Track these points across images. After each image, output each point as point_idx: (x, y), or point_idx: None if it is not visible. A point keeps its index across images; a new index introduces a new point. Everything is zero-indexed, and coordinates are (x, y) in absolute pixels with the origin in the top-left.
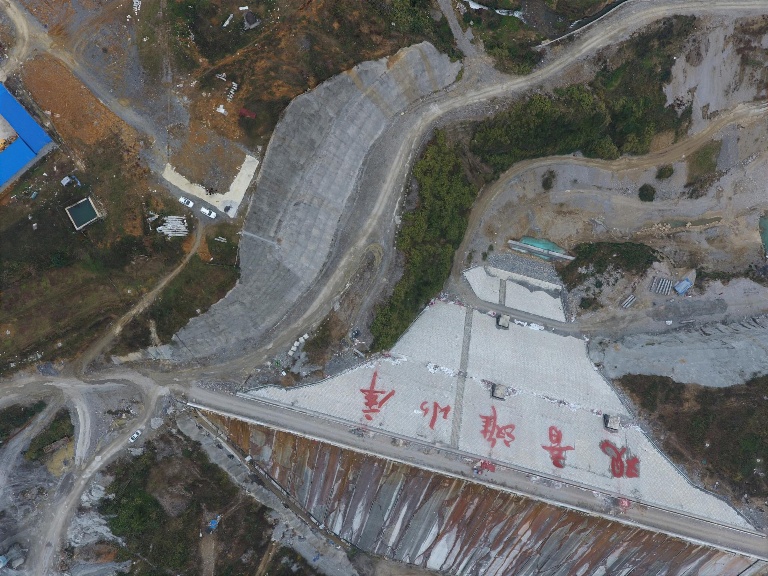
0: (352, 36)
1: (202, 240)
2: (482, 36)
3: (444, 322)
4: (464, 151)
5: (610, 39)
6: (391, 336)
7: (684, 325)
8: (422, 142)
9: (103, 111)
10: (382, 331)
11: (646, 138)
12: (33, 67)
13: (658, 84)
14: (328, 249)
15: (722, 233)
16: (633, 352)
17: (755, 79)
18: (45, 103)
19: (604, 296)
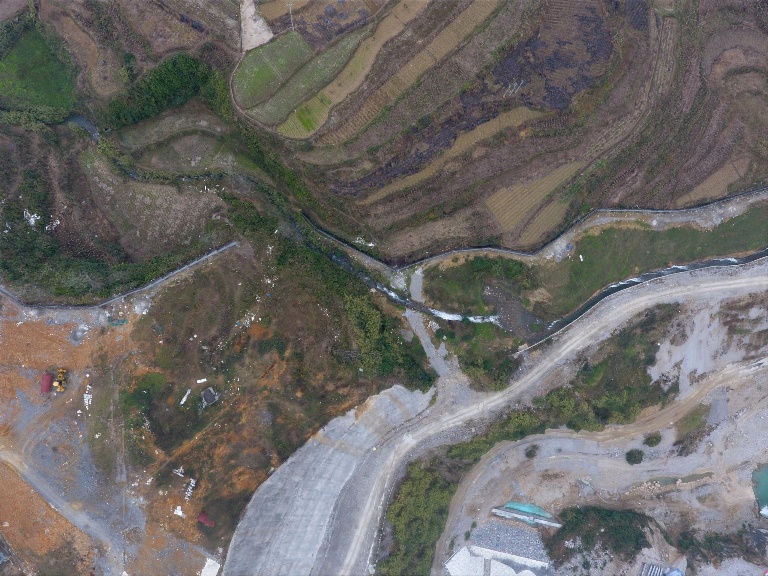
0: (317, 399)
1: None
2: (456, 351)
3: None
4: (441, 460)
5: (590, 339)
6: None
7: None
8: (395, 481)
9: (55, 517)
10: None
11: (631, 416)
12: None
13: (642, 368)
14: None
15: (714, 491)
16: None
17: (743, 343)
18: None
19: None
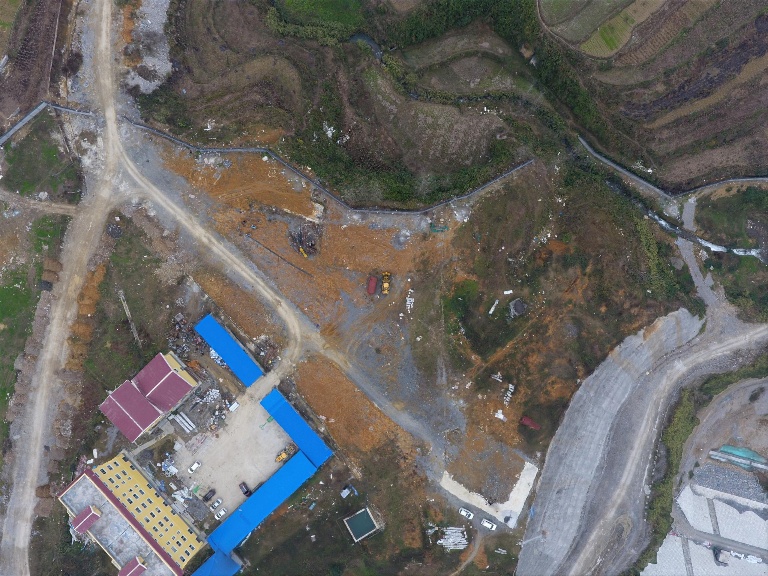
0: (616, 315)
1: (480, 550)
2: (722, 282)
3: (665, 561)
4: None
5: None
6: None
7: None
8: (669, 405)
9: (378, 416)
10: None
11: None
12: (306, 370)
13: None
14: (578, 523)
15: None
16: None
17: None
18: (319, 407)
19: None
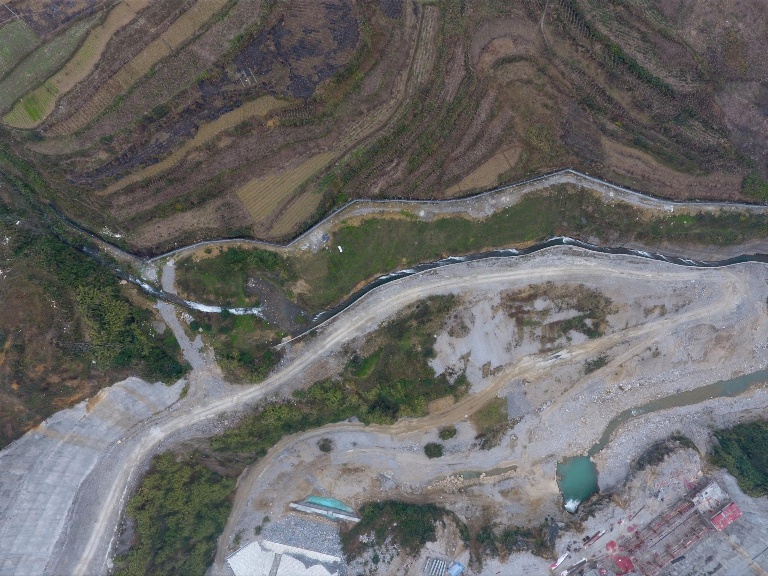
0: (38, 391)
1: None
2: (212, 343)
3: None
4: (206, 454)
5: (357, 331)
6: None
7: None
8: (138, 474)
9: None
10: None
11: (418, 409)
12: None
13: (422, 360)
14: None
15: (517, 484)
16: None
17: (536, 335)
18: None
19: (378, 575)
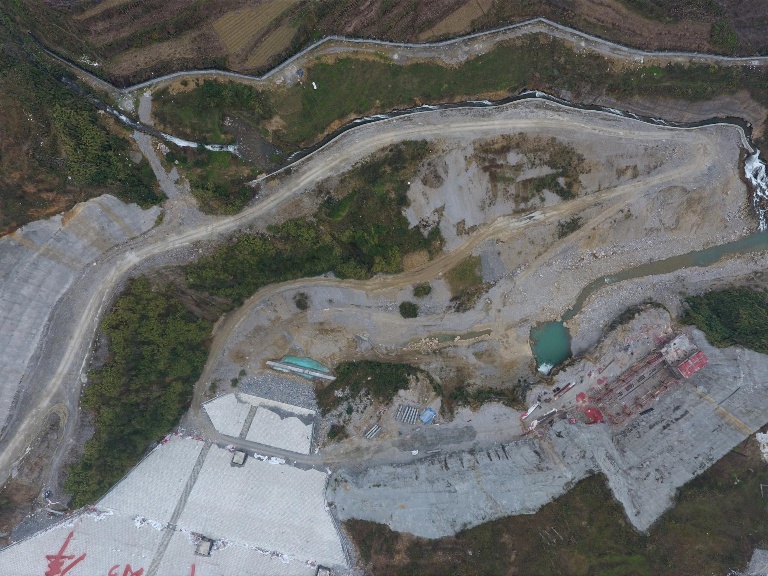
0: (14, 198)
1: None
2: (188, 175)
3: (172, 463)
4: (182, 290)
5: (331, 170)
6: (92, 492)
7: (430, 455)
8: (113, 294)
9: None
10: (78, 489)
11: (392, 261)
12: None
13: (396, 208)
14: (8, 412)
15: (491, 347)
16: (361, 493)
17: (510, 194)
18: None
19: (352, 424)
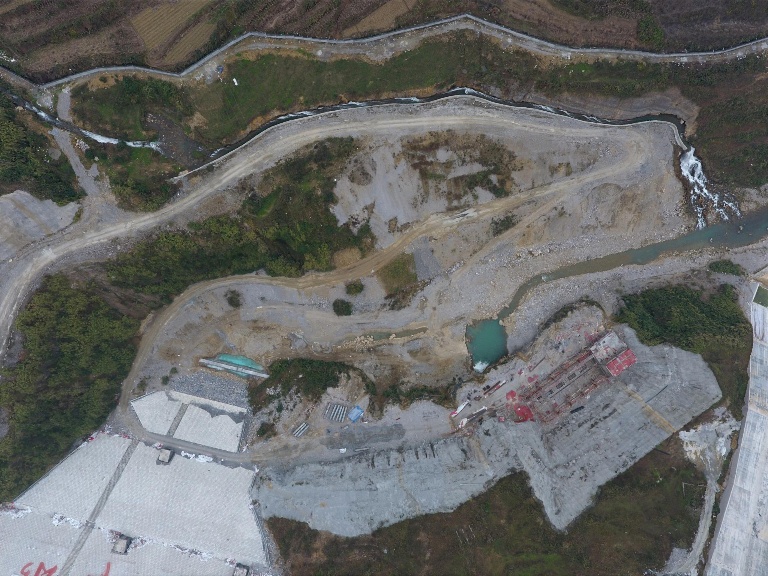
0: None
1: None
2: (108, 172)
3: (96, 460)
4: (105, 287)
5: (254, 167)
6: (8, 490)
7: (358, 453)
8: (28, 291)
9: None
10: None
11: (321, 258)
12: None
13: (323, 206)
14: None
15: (426, 345)
16: (284, 491)
17: (442, 191)
18: None
19: (281, 422)
